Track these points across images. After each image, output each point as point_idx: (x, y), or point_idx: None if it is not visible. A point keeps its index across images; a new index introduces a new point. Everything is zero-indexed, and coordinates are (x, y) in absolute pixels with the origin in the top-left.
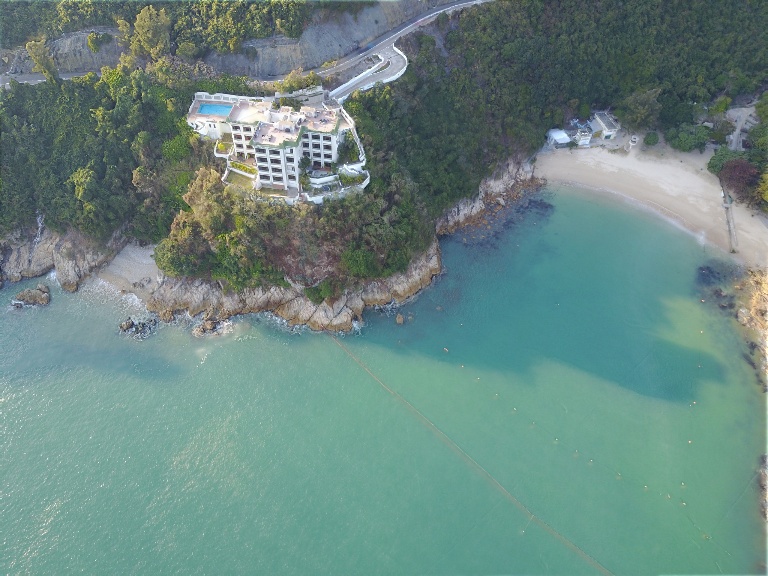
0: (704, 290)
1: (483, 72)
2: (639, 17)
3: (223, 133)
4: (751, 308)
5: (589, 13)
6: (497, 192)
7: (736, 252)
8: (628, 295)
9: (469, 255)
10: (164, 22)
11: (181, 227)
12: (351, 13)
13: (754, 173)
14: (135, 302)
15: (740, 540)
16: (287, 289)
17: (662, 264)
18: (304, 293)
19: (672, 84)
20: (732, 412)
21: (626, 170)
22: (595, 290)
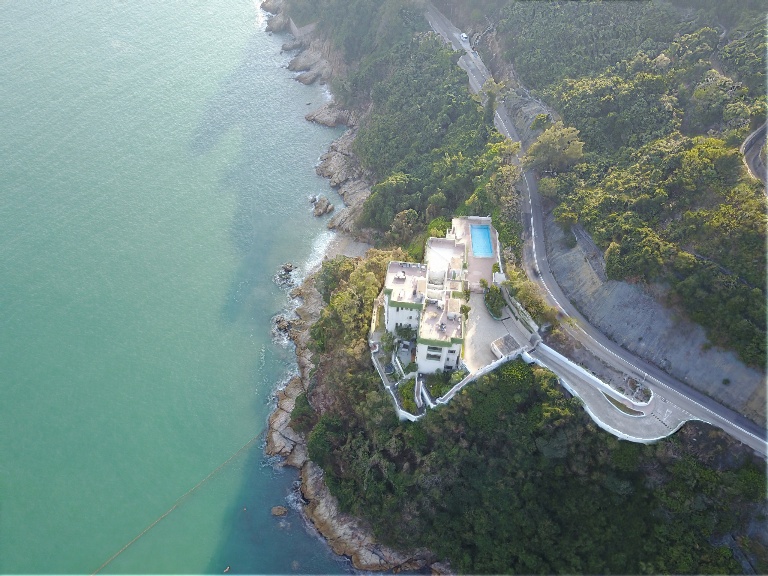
0: None
1: None
2: None
3: None
4: None
5: None
6: None
7: None
8: None
9: None
10: (557, 148)
11: (354, 262)
12: (709, 336)
13: None
14: (315, 268)
15: None
16: None
17: None
18: None
19: None
20: None
21: None
22: None
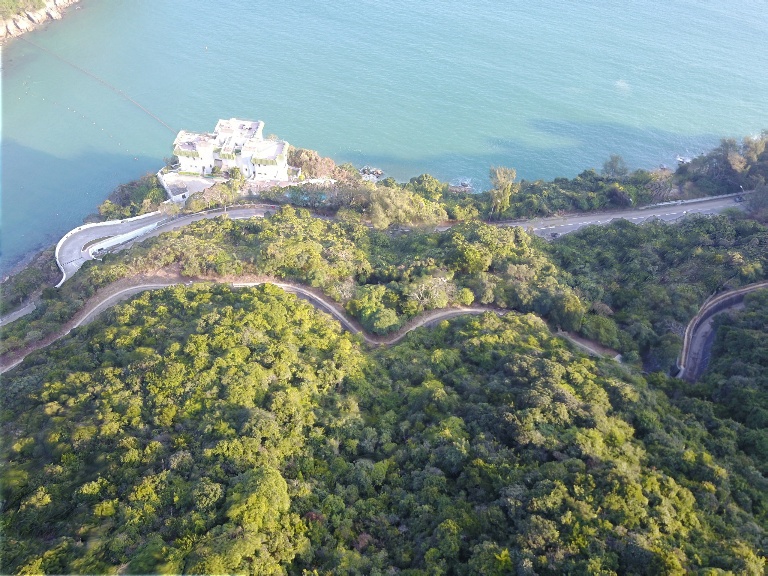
0: None
1: None
2: None
3: None
4: None
5: None
6: None
7: None
8: None
9: None
10: (371, 195)
11: None
12: None
13: None
14: None
15: (7, 84)
16: None
17: None
18: None
19: None
20: None
21: None
22: None
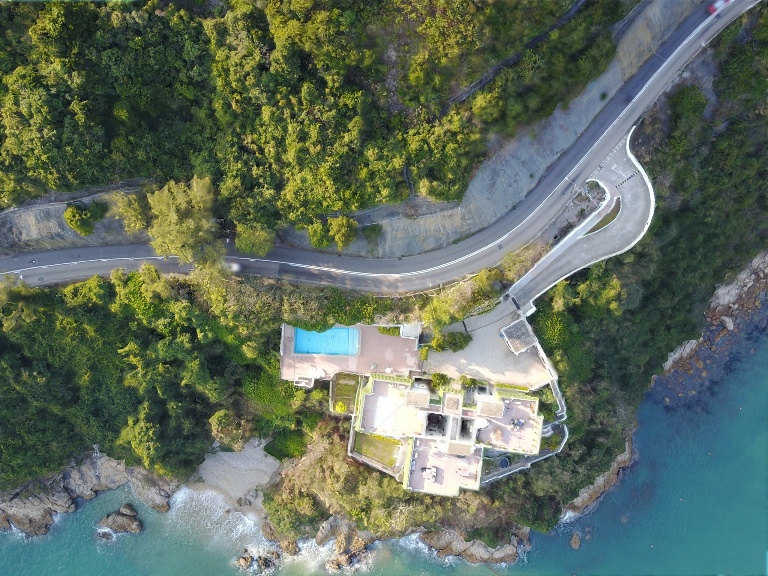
0: None
1: None
2: None
3: None
4: None
5: None
6: (725, 304)
7: None
8: None
9: (670, 426)
10: (208, 225)
11: (297, 495)
12: (559, 101)
13: None
14: (246, 525)
15: None
16: None
17: None
18: None
19: None
20: None
21: None
22: None
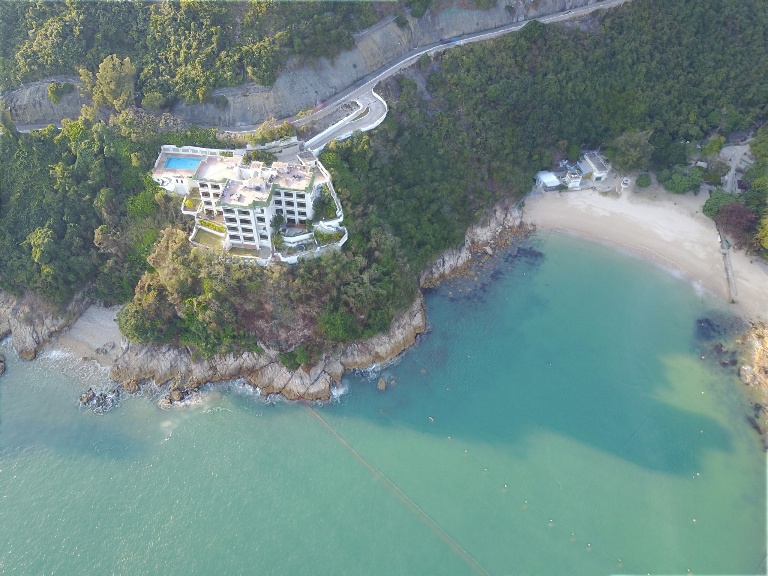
0: (704, 345)
1: (467, 115)
2: (628, 54)
3: (192, 188)
4: (754, 365)
5: (576, 51)
6: (484, 240)
7: (736, 302)
8: (624, 353)
9: (455, 310)
10: (128, 72)
11: (146, 291)
12: (328, 58)
13: (752, 218)
14: (97, 370)
15: None
16: (260, 354)
17: (659, 317)
18: (279, 359)
19: (663, 123)
20: (738, 484)
21: (618, 214)
22: (589, 348)
